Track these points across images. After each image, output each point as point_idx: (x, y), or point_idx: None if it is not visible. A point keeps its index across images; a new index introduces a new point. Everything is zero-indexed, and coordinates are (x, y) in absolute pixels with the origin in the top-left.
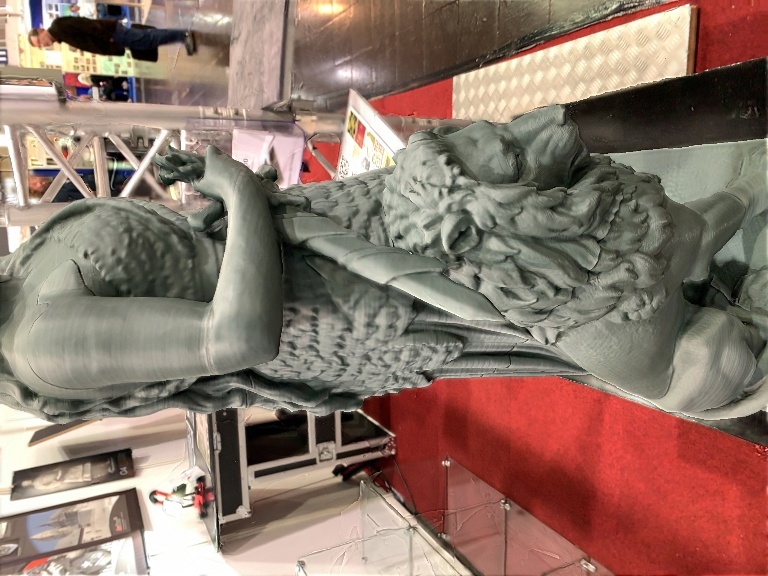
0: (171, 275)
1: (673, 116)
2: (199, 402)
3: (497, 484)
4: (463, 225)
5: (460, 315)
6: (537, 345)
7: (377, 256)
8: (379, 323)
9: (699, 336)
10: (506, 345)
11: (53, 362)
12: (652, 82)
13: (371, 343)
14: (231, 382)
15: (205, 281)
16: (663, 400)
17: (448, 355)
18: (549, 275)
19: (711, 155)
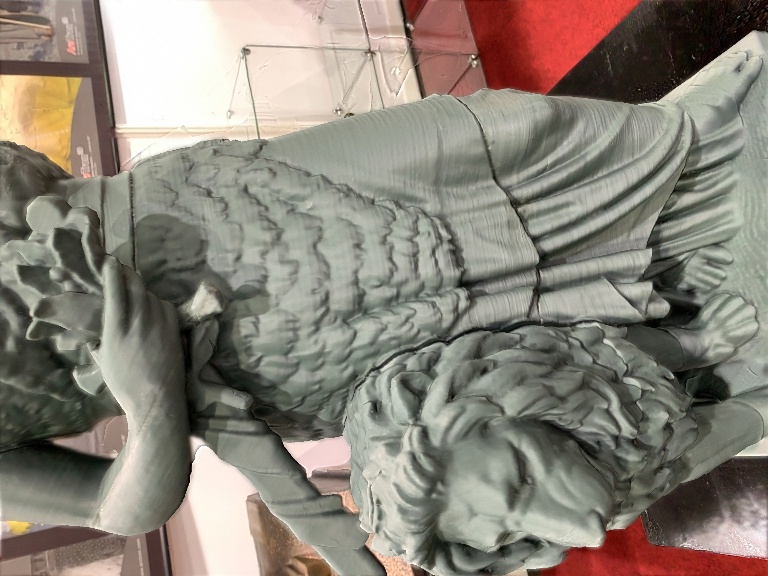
0: (52, 421)
1: None
2: None
3: (479, 35)
4: None
5: None
6: None
7: (299, 519)
8: None
9: None
10: None
11: None
12: None
13: None
14: None
15: (99, 410)
16: None
17: None
18: None
19: None
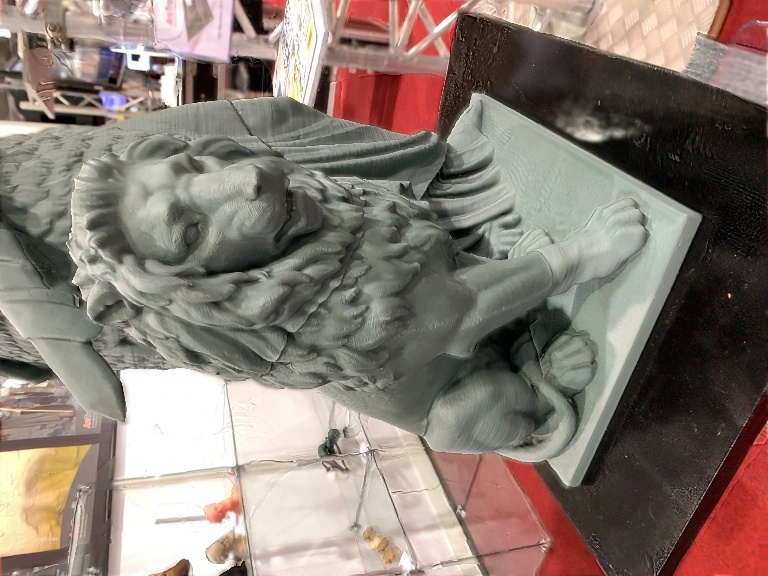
0: None
1: (581, 101)
2: None
3: None
4: (108, 300)
5: None
6: None
7: (22, 305)
8: None
9: (451, 407)
10: None
11: None
12: (577, 44)
13: None
14: None
15: None
16: None
17: None
18: None
19: (587, 176)
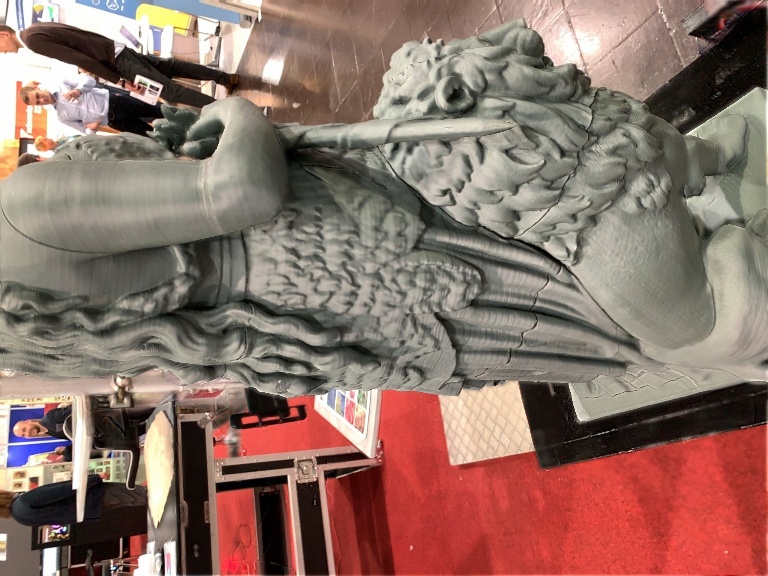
0: None
1: None
2: (190, 333)
3: None
4: (455, 83)
5: (470, 127)
6: (560, 299)
7: (377, 120)
8: (387, 229)
9: (722, 240)
10: (527, 295)
11: (30, 200)
12: None
13: (381, 254)
14: (228, 310)
15: None
16: (715, 334)
17: (467, 288)
18: (549, 130)
19: None
